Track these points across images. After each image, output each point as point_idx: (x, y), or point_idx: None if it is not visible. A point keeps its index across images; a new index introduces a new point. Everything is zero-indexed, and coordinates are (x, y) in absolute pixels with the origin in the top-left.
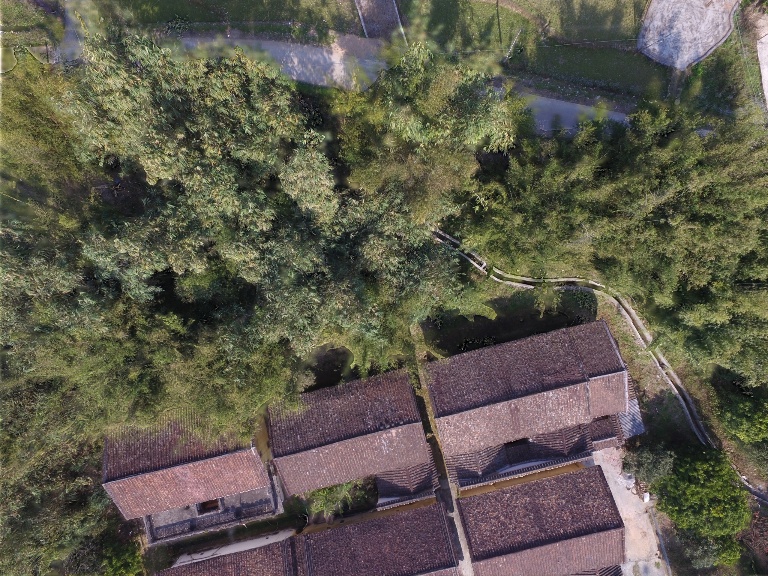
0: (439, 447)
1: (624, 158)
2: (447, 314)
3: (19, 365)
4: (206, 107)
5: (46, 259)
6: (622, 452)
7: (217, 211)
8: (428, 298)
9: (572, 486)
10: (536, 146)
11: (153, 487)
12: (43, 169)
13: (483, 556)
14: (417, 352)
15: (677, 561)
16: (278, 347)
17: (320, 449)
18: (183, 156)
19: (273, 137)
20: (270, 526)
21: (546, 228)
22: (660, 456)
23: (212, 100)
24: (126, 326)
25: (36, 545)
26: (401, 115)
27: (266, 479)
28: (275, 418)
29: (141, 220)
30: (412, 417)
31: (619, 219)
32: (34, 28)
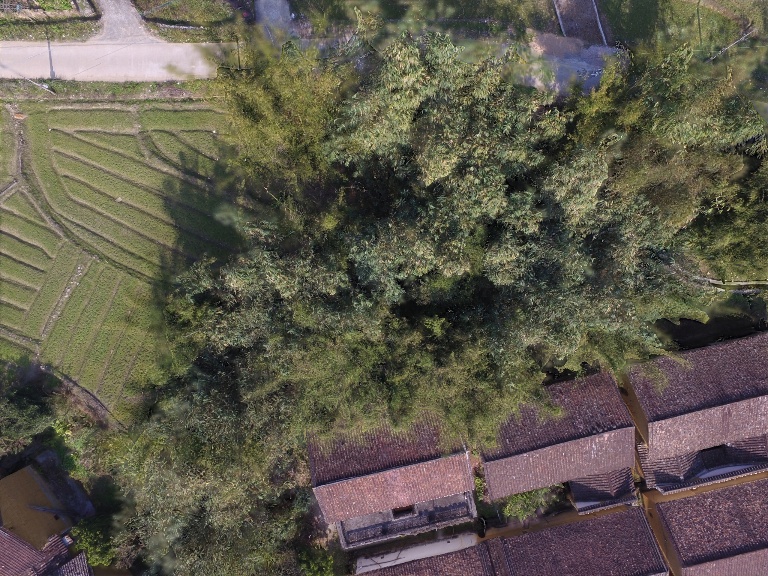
0: None
1: None
2: None
3: (276, 368)
4: None
5: None
6: None
7: (480, 212)
8: None
9: None
10: None
11: (361, 491)
12: (282, 168)
13: (693, 561)
14: None
15: None
16: (525, 351)
17: (531, 453)
18: None
19: (538, 137)
20: (446, 530)
21: None
22: None
23: (470, 99)
24: None
25: None
26: (672, 116)
27: (473, 483)
28: None
29: (403, 221)
30: (625, 421)
31: None
32: (226, 24)
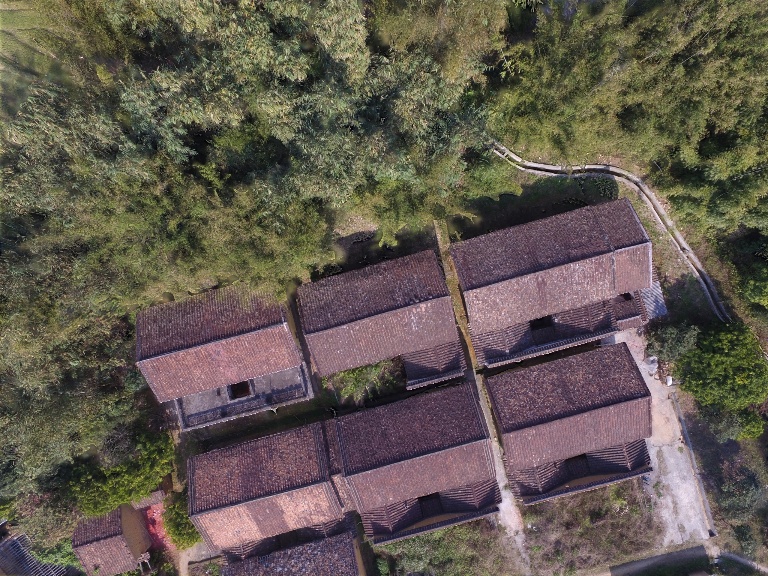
0: (464, 338)
1: (651, 4)
2: (470, 203)
3: (59, 220)
4: None
5: None
6: (644, 339)
7: (252, 64)
8: (457, 164)
9: (598, 362)
10: (563, 3)
11: (186, 366)
12: None
13: (513, 428)
14: (441, 244)
15: (700, 444)
16: (312, 205)
17: (351, 325)
18: (218, 6)
19: None
20: (298, 421)
21: (575, 78)
22: (684, 332)
23: None
24: (163, 184)
25: (74, 417)
26: None
27: (297, 358)
28: (305, 299)
29: None
30: (441, 292)
31: (647, 67)
32: None
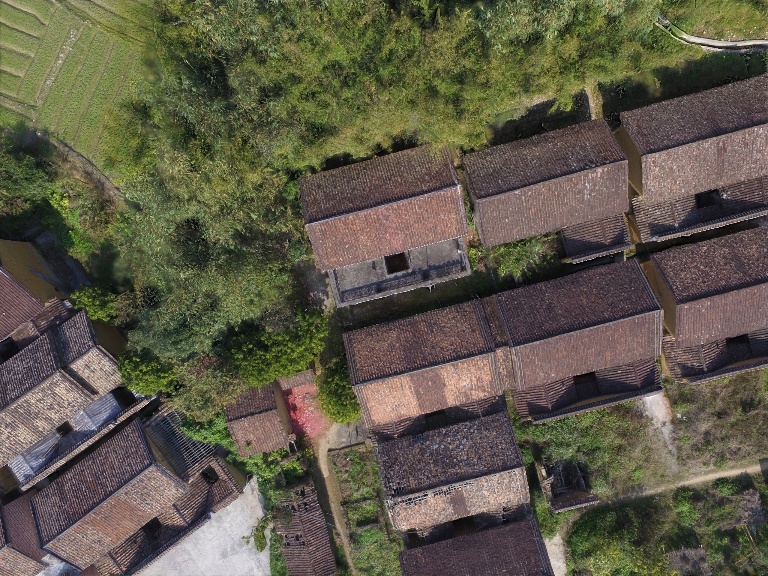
0: None
1: None
2: (630, 80)
3: (263, 49)
4: None
5: None
6: None
7: None
8: (652, 12)
9: None
10: None
11: (354, 231)
12: None
13: (687, 299)
14: None
15: None
16: (514, 44)
17: (523, 190)
18: None
19: None
20: None
21: None
22: None
23: None
24: None
25: None
26: None
27: (465, 226)
28: (472, 167)
29: None
30: (618, 156)
31: None
32: None
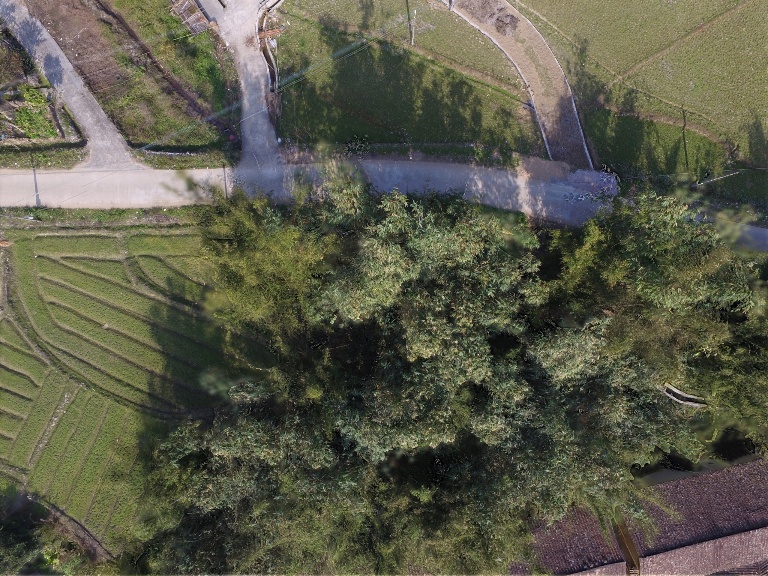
0: None
1: None
2: None
3: (262, 538)
4: (445, 267)
5: (290, 429)
6: None
7: (465, 379)
8: None
9: None
10: None
11: None
12: (267, 323)
13: None
14: None
15: None
16: None
17: None
18: None
19: (523, 304)
20: None
21: None
22: None
23: (454, 262)
24: (363, 491)
25: None
26: (657, 283)
27: None
28: None
29: (388, 389)
30: (616, 556)
31: None
32: (212, 150)
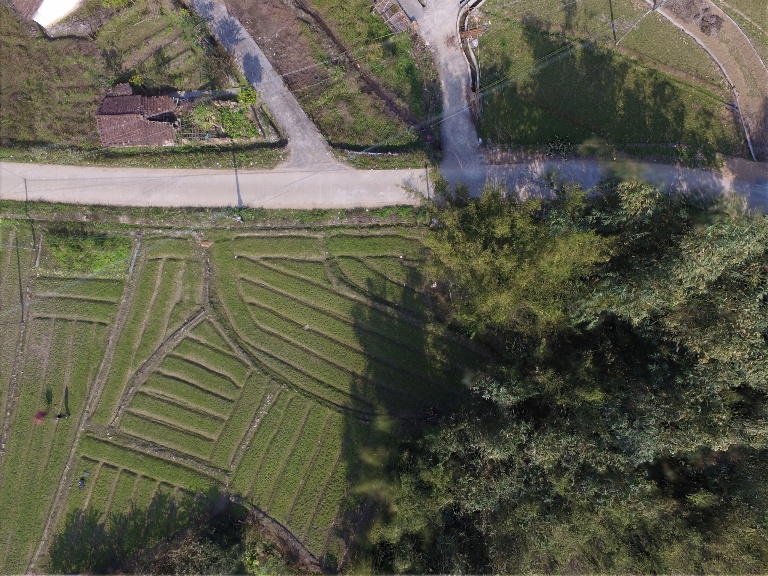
0: None
1: None
2: None
3: (536, 540)
4: None
5: None
6: None
7: (741, 382)
8: None
9: None
10: None
11: None
12: (520, 325)
13: None
14: None
15: None
16: None
17: None
18: None
19: None
20: None
21: None
22: None
23: None
24: None
25: None
26: None
27: None
28: None
29: (664, 391)
30: None
31: None
32: (416, 151)
